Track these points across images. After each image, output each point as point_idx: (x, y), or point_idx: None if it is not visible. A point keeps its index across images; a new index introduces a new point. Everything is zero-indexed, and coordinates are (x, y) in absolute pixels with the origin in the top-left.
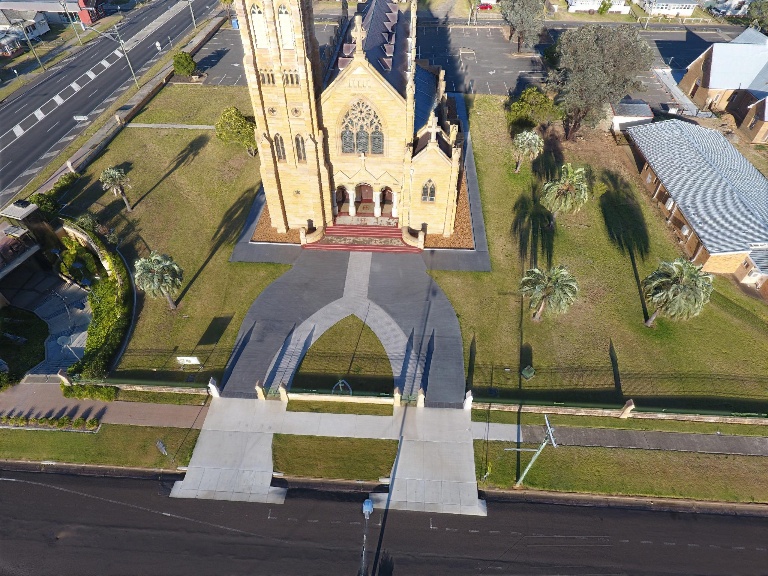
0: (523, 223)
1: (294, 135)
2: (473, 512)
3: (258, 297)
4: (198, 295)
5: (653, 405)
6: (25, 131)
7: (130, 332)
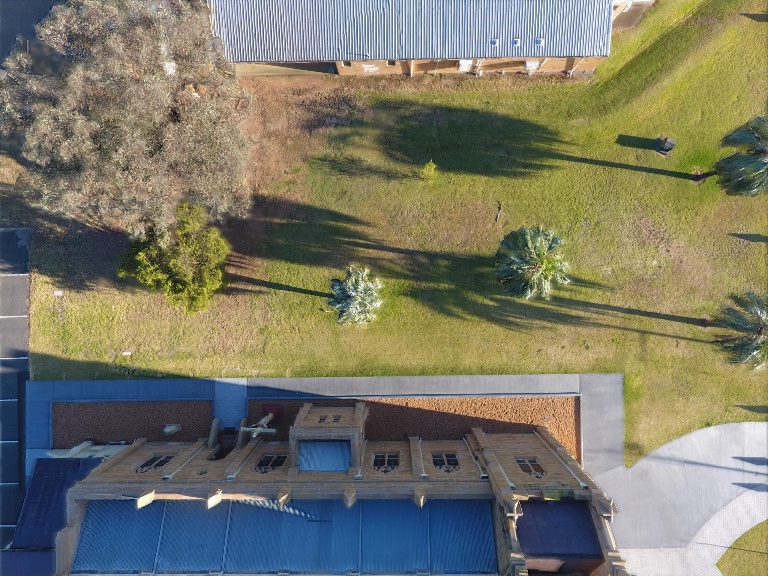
0: (503, 311)
1: None
2: None
3: None
4: None
5: None
6: None
7: None
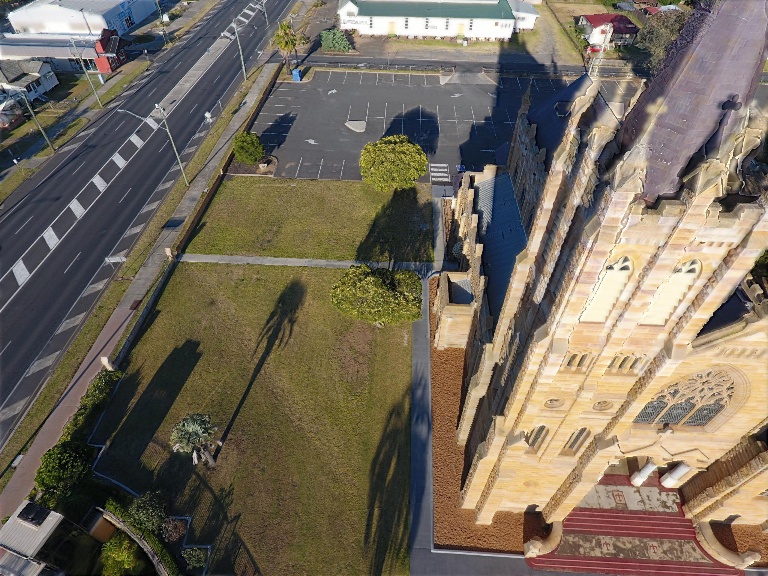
0: None
1: (575, 428)
2: None
3: None
4: None
5: None
6: (31, 273)
7: None
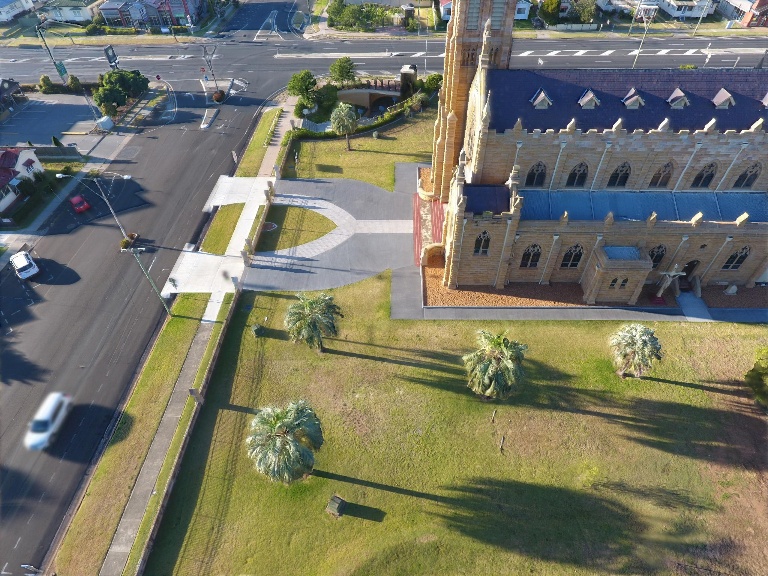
0: None
1: None
2: (164, 290)
3: (358, 180)
4: (359, 156)
5: (202, 434)
6: (527, 55)
7: (329, 140)
